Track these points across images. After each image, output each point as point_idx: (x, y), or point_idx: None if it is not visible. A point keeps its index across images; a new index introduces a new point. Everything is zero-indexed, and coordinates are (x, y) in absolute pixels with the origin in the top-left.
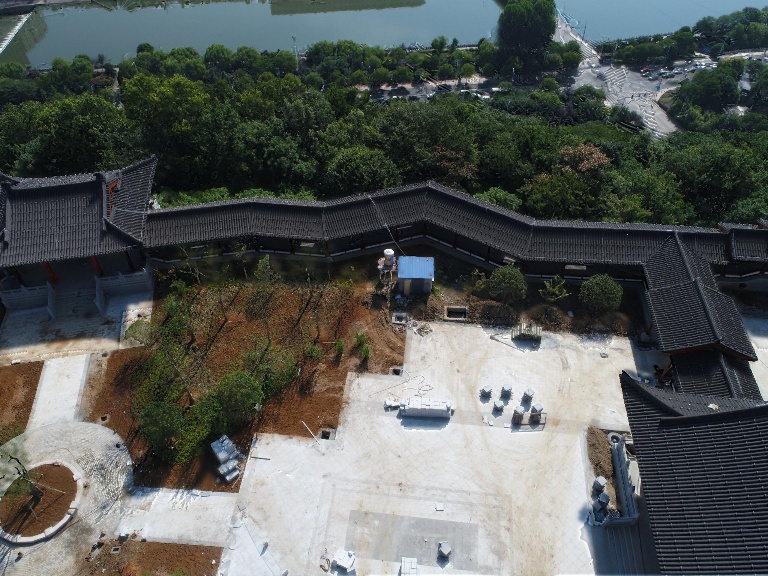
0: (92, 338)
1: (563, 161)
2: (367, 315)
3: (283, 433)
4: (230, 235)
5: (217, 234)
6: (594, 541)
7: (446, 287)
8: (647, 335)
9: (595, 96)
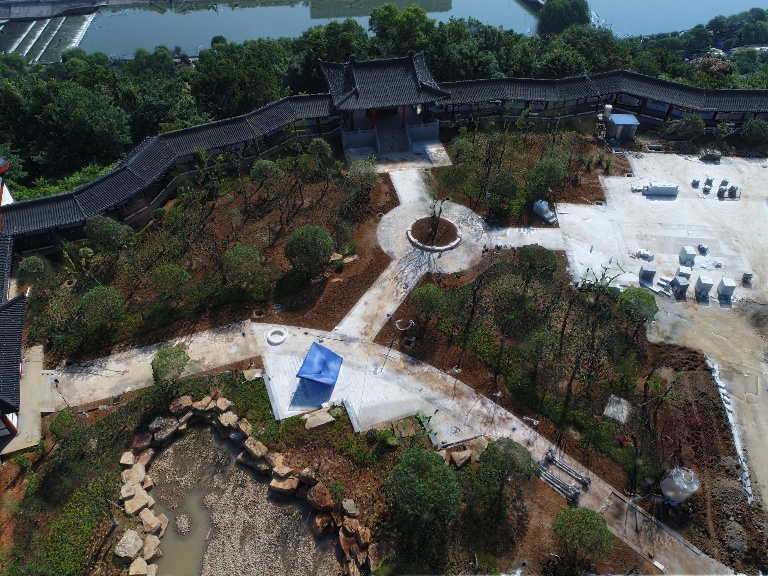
0: (413, 162)
1: None
2: (596, 148)
3: (572, 203)
4: (493, 99)
5: (484, 98)
6: None
7: (641, 136)
8: None
9: None
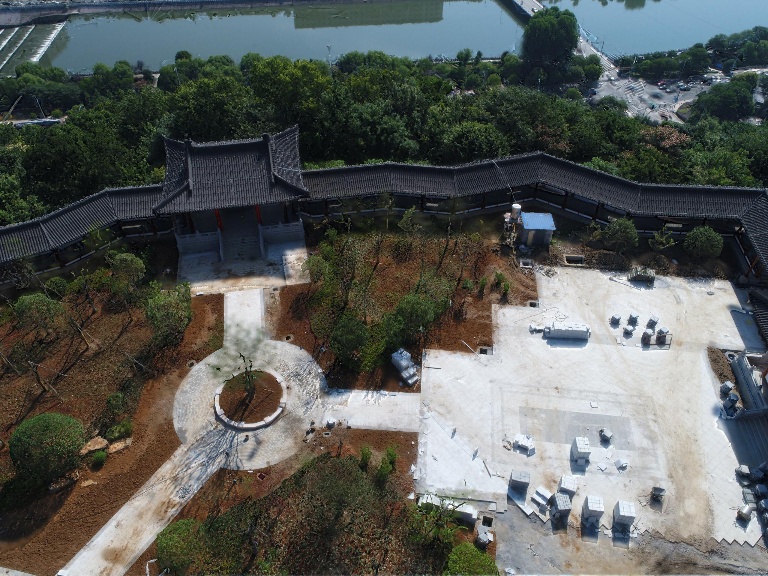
0: (261, 276)
1: (644, 141)
2: (498, 260)
3: (447, 349)
4: (374, 192)
5: (362, 191)
6: (729, 430)
7: (561, 240)
8: (746, 277)
9: (617, 106)
